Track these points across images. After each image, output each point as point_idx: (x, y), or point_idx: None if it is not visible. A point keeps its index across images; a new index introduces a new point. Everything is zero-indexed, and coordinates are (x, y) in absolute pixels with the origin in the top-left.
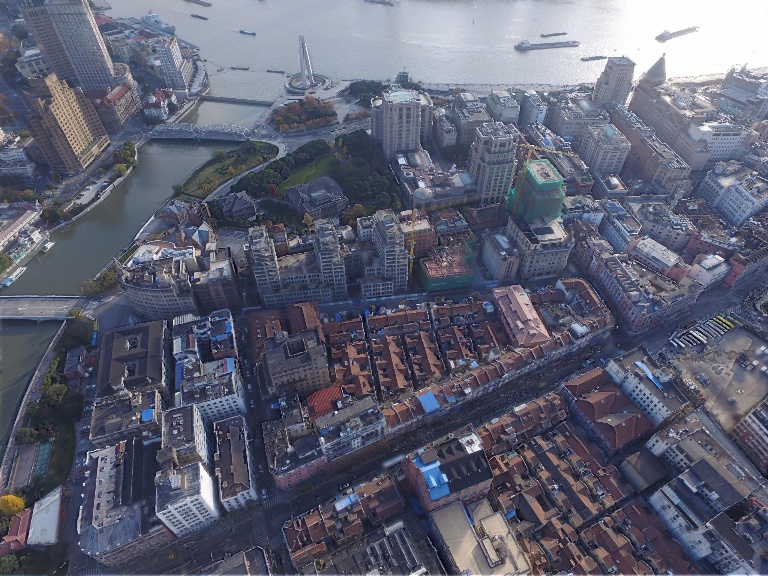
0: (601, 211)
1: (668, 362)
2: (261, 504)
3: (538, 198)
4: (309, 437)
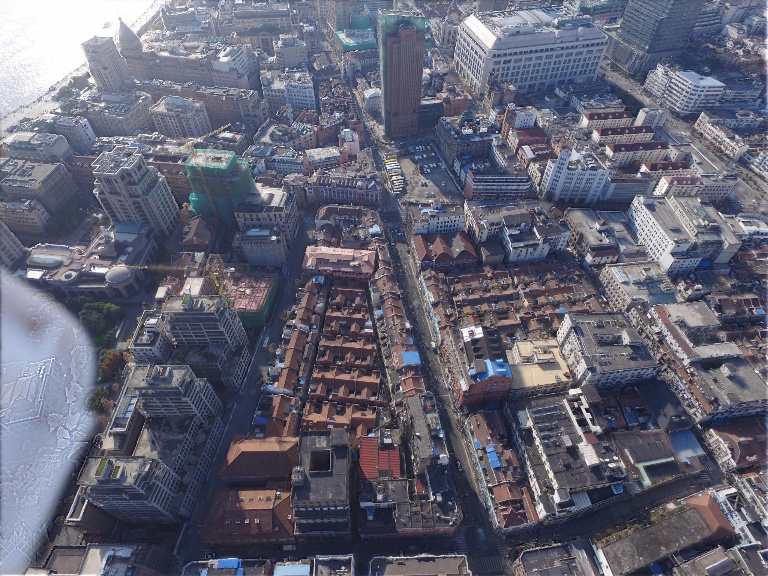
0: (260, 159)
1: None
2: None
3: (238, 179)
4: (429, 474)
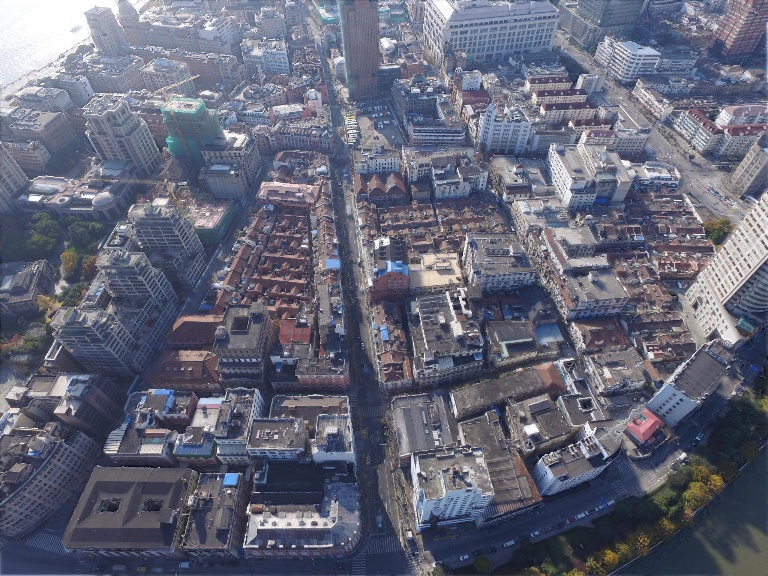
0: (232, 112)
1: None
2: (352, 408)
3: (205, 123)
4: (327, 340)
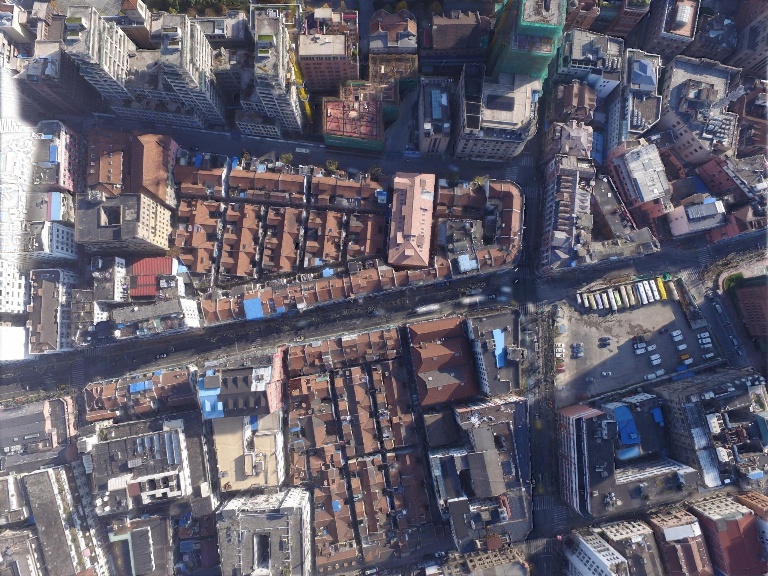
0: (618, 76)
1: (554, 320)
2: (82, 352)
3: (511, 49)
4: None
